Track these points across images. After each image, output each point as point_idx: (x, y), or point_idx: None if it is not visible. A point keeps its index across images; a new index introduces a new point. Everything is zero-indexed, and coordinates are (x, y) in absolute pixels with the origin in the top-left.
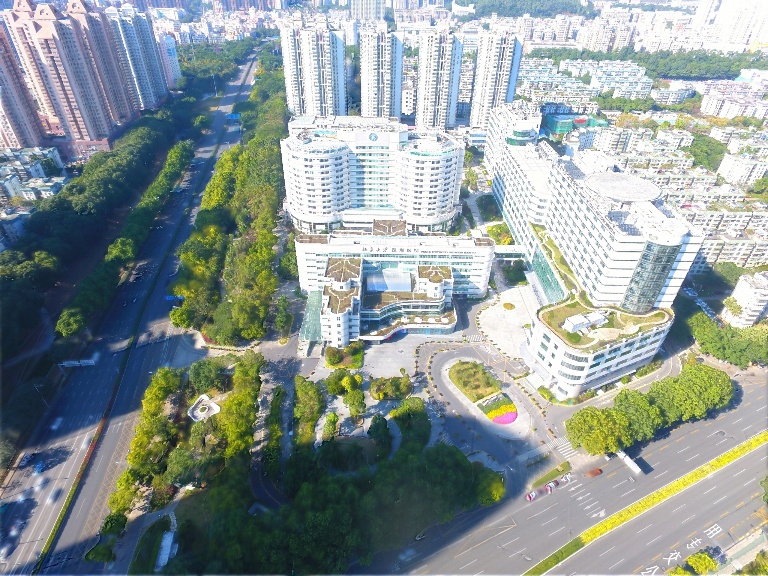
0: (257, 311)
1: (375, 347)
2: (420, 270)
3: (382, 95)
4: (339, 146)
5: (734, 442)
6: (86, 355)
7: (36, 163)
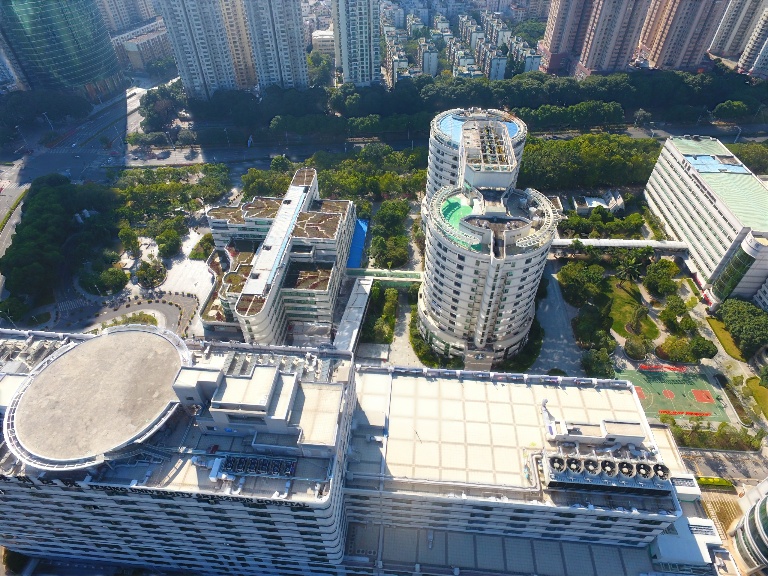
0: (252, 183)
1: None
2: None
3: None
4: (447, 138)
5: None
6: (272, 148)
7: (502, 58)
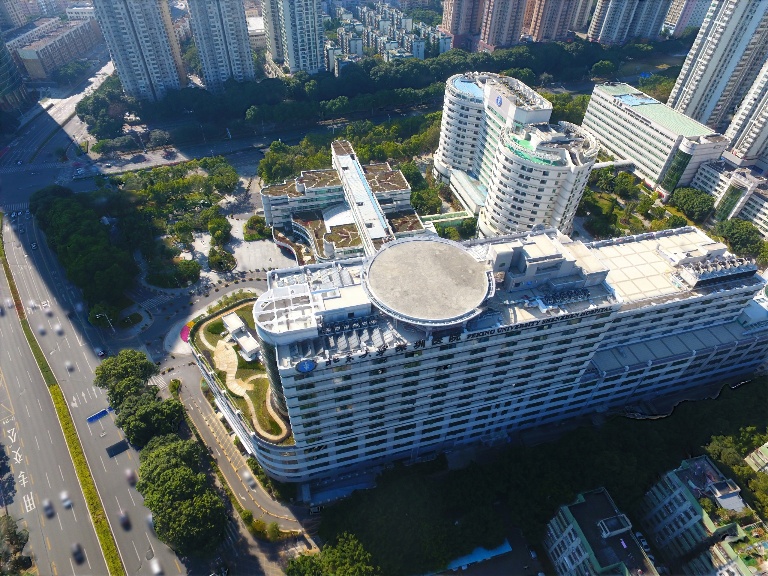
0: (274, 166)
1: (273, 244)
2: (347, 226)
3: (764, 104)
4: (471, 95)
5: (132, 567)
6: (249, 138)
7: (421, 41)
